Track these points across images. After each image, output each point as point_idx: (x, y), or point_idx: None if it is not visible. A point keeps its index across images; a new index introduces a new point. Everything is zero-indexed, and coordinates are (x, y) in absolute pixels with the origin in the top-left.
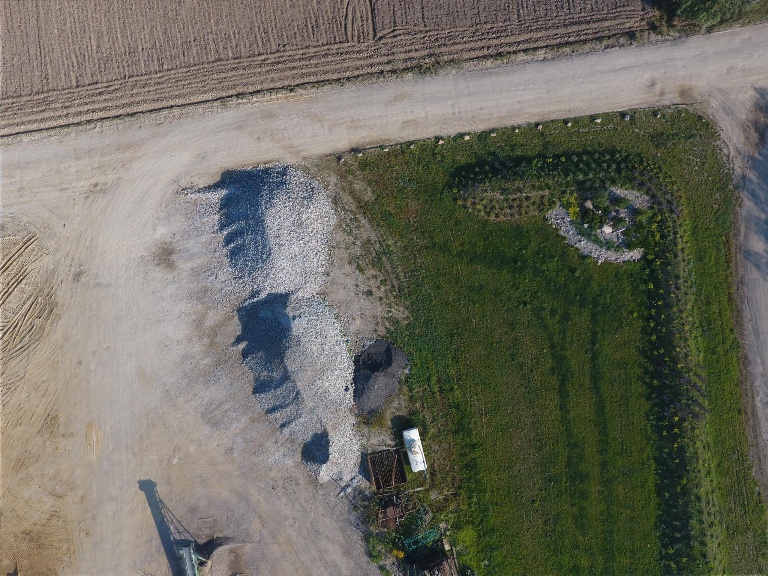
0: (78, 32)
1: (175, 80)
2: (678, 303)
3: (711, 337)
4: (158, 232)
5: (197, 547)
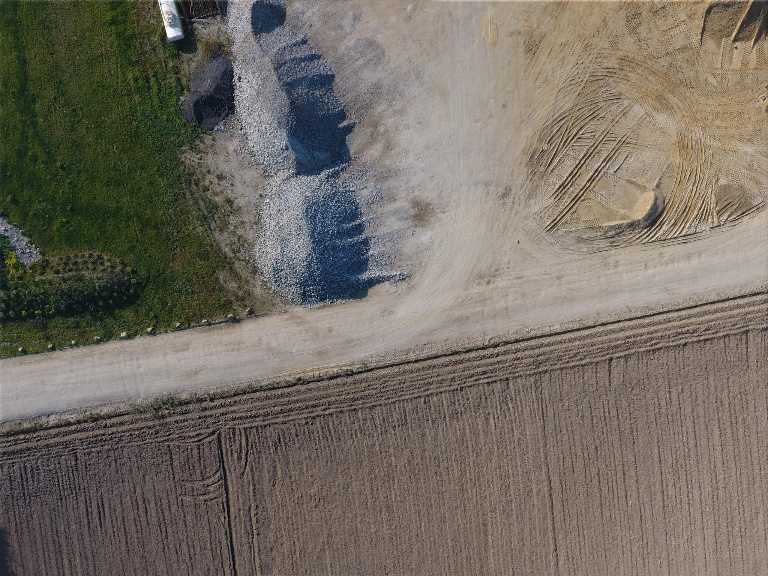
0: (507, 433)
1: (413, 387)
2: None
3: None
4: (428, 237)
5: None
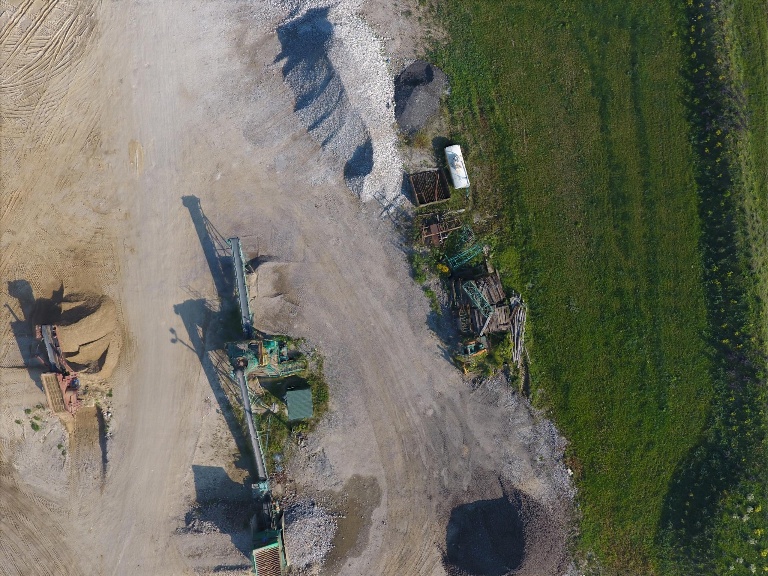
0: None
1: None
2: (718, 14)
3: (751, 57)
4: None
5: None
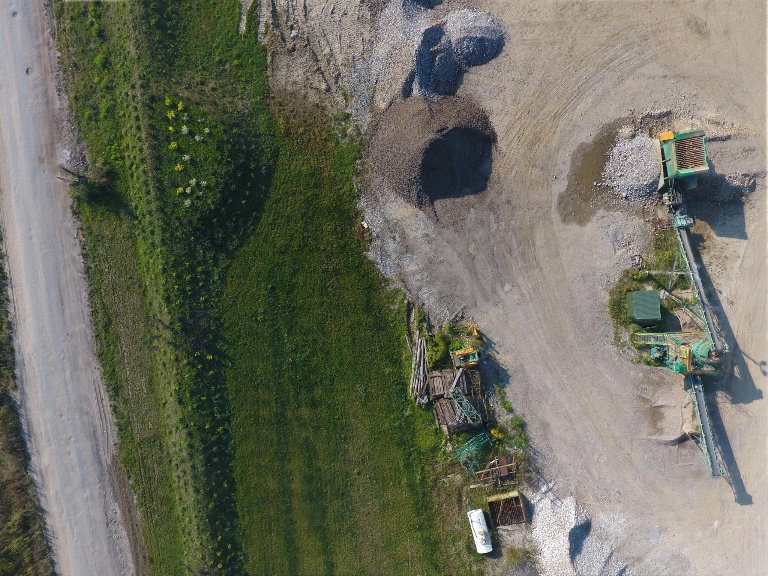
0: None
1: None
2: None
3: None
4: None
5: None
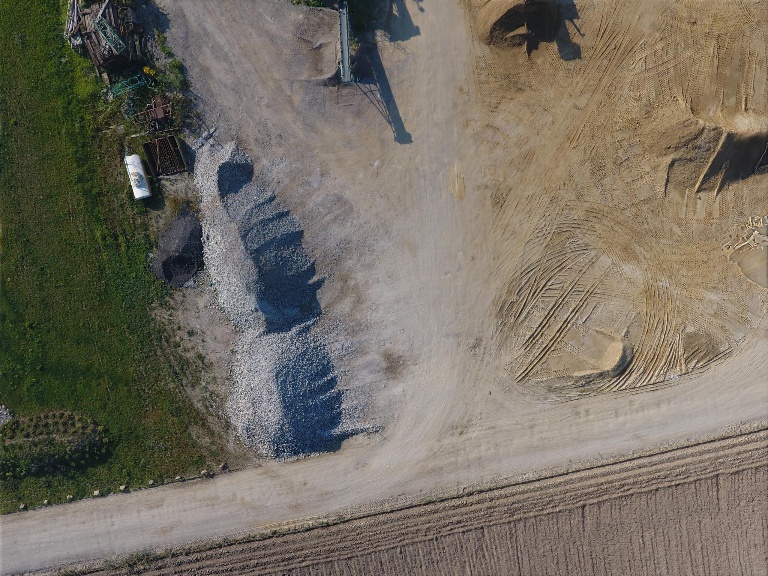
0: None
1: (389, 538)
2: None
3: None
4: (401, 389)
5: (354, 76)
